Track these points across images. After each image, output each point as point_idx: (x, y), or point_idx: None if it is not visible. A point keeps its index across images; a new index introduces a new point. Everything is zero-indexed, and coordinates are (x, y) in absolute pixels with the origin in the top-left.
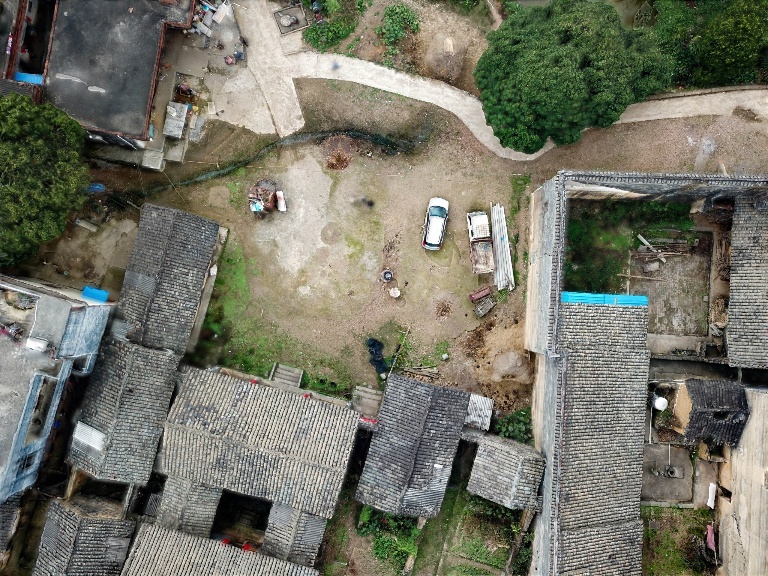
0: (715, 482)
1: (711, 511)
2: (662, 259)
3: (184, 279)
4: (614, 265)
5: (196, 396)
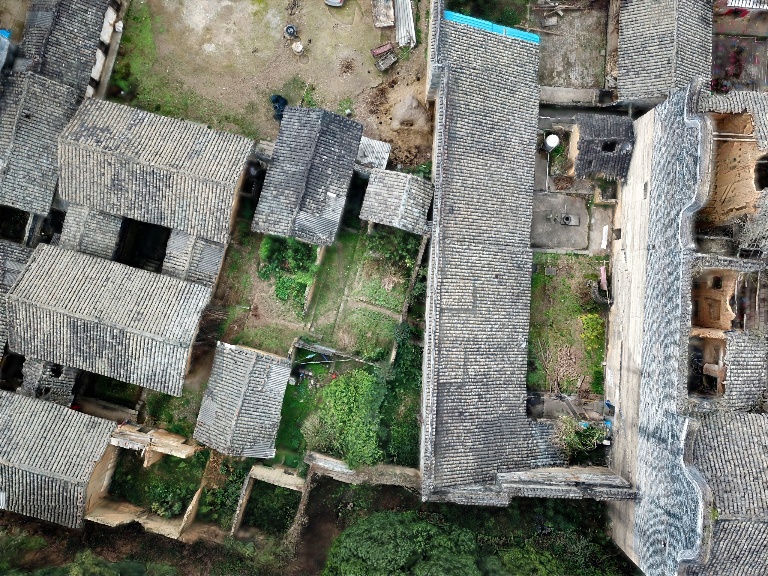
0: (610, 228)
1: (606, 257)
2: (559, 12)
3: (83, 17)
4: (511, 16)
5: (91, 120)
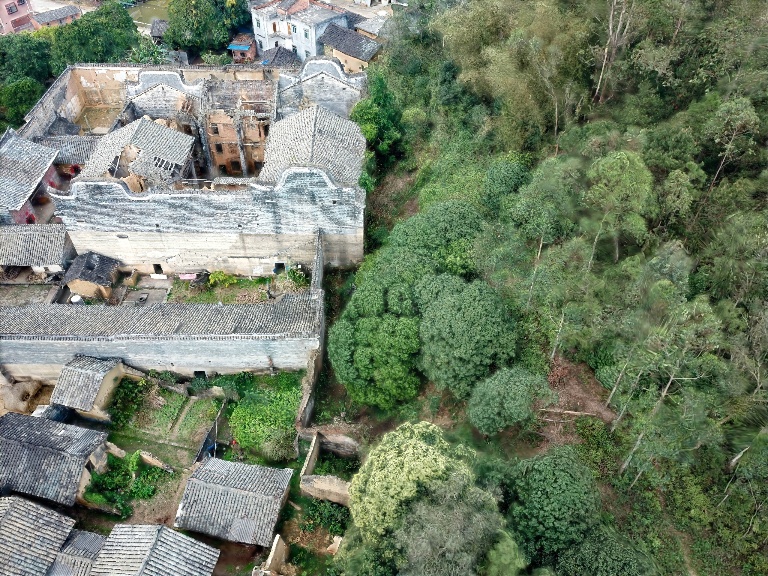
0: None
1: (175, 279)
2: None
3: None
4: None
5: None
